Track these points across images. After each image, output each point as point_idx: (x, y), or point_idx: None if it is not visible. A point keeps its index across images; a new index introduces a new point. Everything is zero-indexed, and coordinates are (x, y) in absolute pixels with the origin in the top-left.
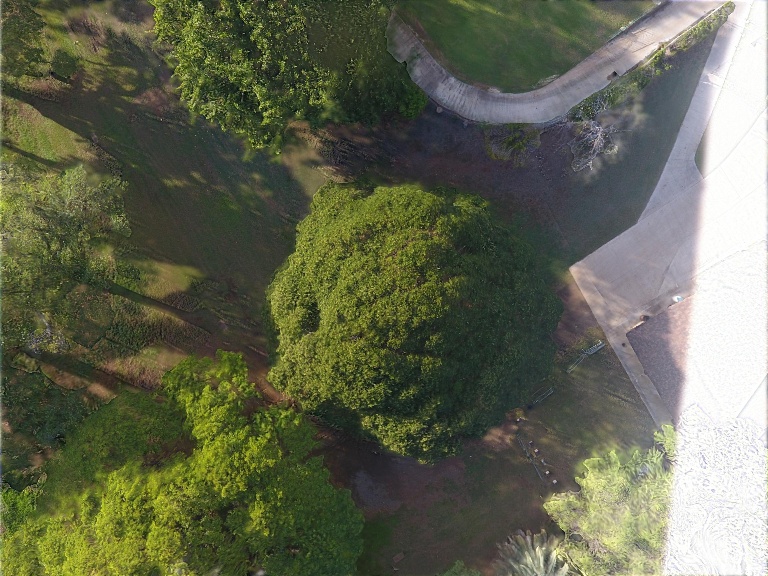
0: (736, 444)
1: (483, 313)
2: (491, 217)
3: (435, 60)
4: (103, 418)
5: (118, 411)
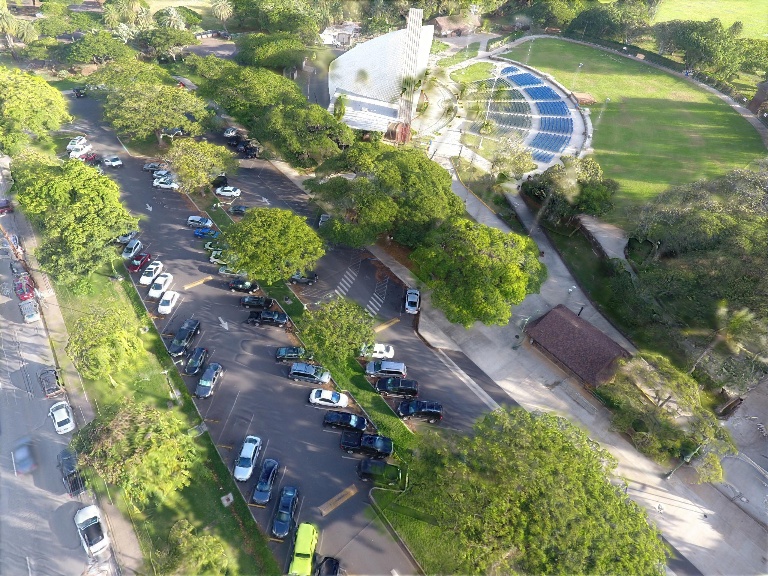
0: (473, 0)
1: (533, 7)
2: (535, 22)
3: (561, 39)
4: (597, 4)
5: (595, 4)
